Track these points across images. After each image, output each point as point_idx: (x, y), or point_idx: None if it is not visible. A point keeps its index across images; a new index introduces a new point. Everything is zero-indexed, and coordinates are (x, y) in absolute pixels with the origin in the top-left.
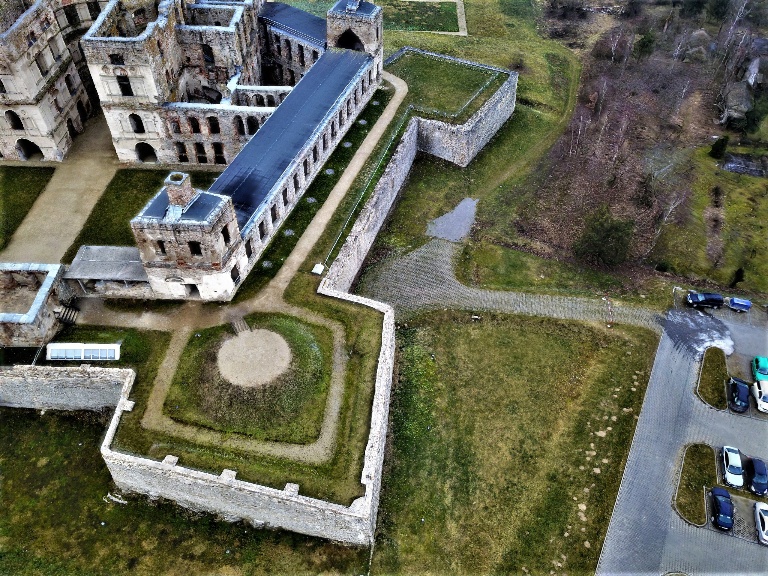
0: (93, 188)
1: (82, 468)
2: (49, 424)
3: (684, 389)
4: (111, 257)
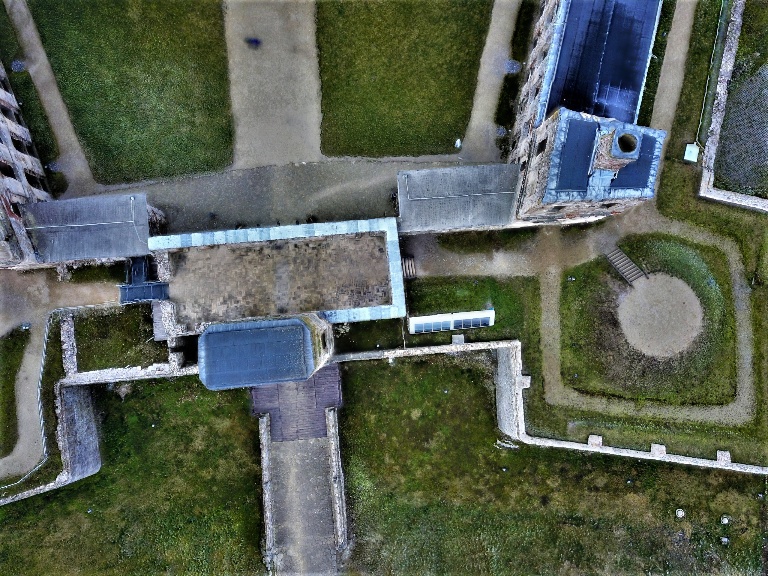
0: None
1: (458, 416)
2: (404, 373)
3: None
4: (447, 189)
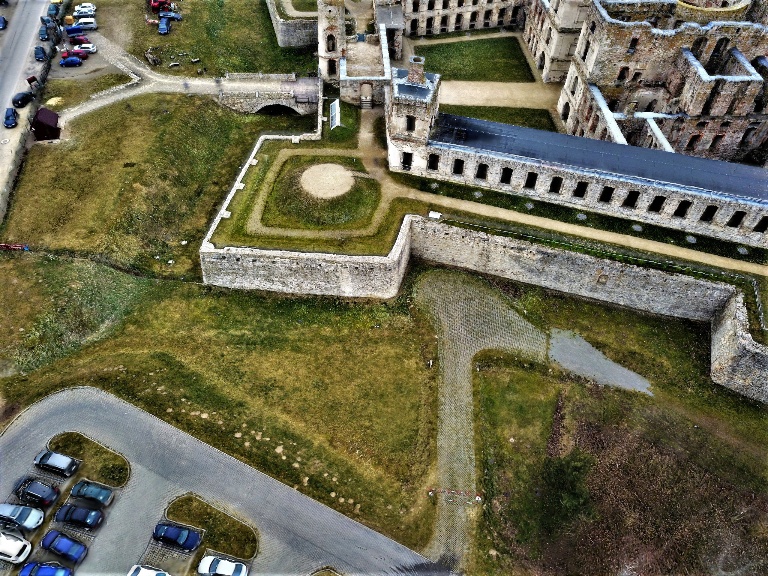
0: (518, 102)
1: None
2: None
3: (333, 554)
4: None
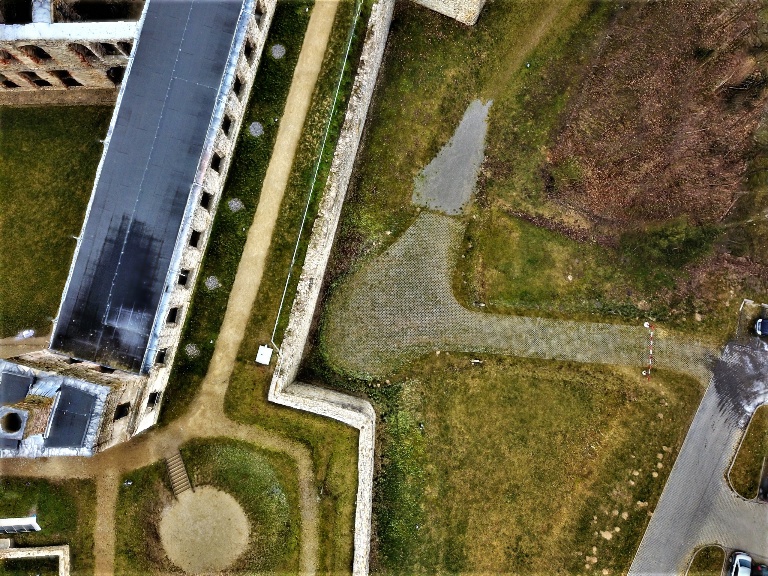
0: None
1: None
2: None
3: (714, 471)
4: None
